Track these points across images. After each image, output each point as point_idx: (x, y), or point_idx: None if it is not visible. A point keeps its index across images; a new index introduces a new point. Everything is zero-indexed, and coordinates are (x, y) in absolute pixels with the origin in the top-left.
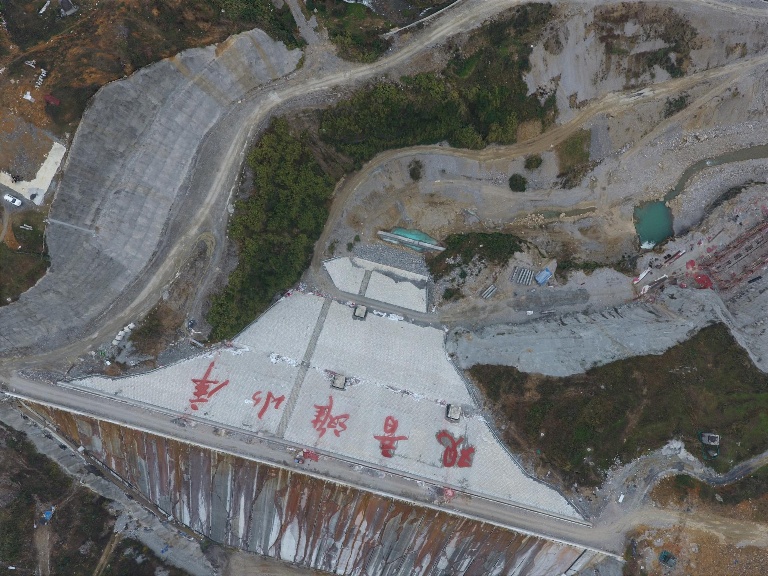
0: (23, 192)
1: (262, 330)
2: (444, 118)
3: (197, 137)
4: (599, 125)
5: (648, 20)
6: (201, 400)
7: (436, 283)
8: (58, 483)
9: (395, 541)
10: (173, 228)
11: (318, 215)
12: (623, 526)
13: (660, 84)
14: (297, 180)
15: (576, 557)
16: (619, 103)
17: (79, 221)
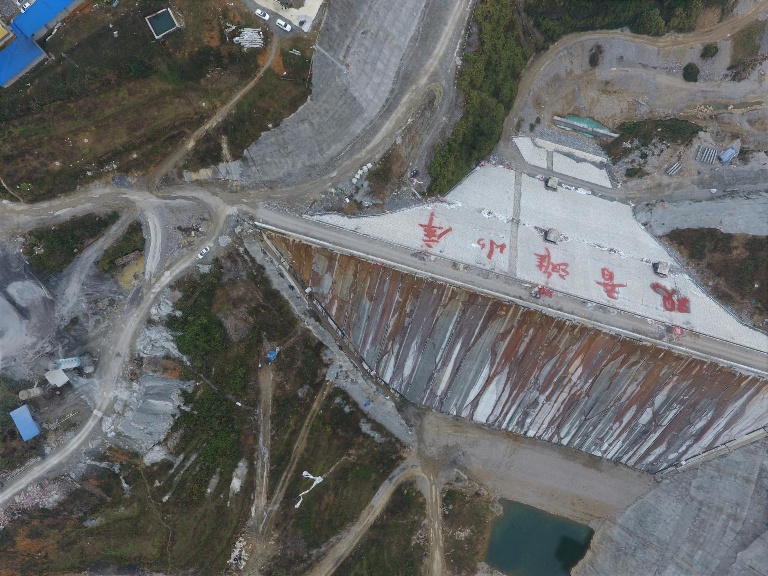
0: (292, 19)
1: (468, 191)
2: None
3: None
4: None
5: None
6: (433, 241)
7: (615, 165)
8: (287, 322)
9: (604, 391)
10: (404, 77)
11: (513, 88)
12: None
13: None
14: (504, 47)
15: None
16: None
17: (335, 54)
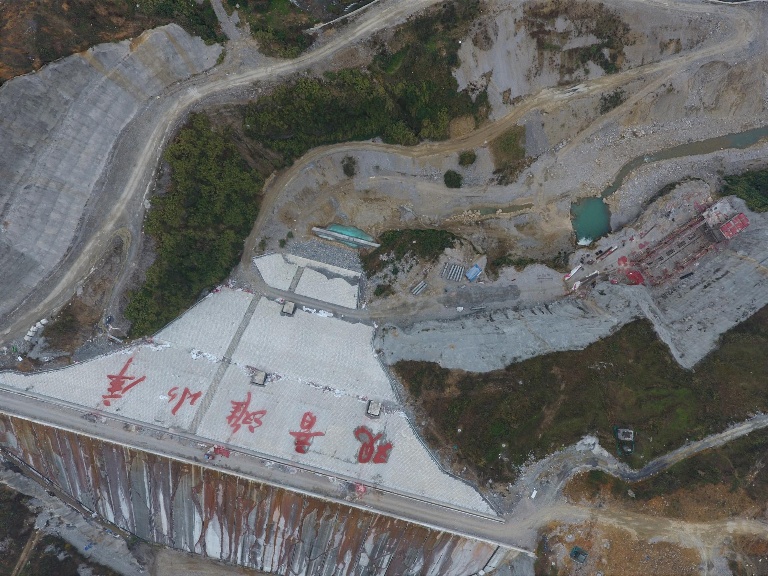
0: None
1: (185, 326)
2: (373, 114)
3: (114, 132)
4: (533, 121)
5: (579, 16)
6: (114, 396)
7: (369, 279)
8: None
9: (314, 538)
10: (88, 223)
11: (246, 211)
12: (535, 522)
13: (595, 80)
14: (221, 176)
15: (491, 553)
16: (553, 99)
17: None
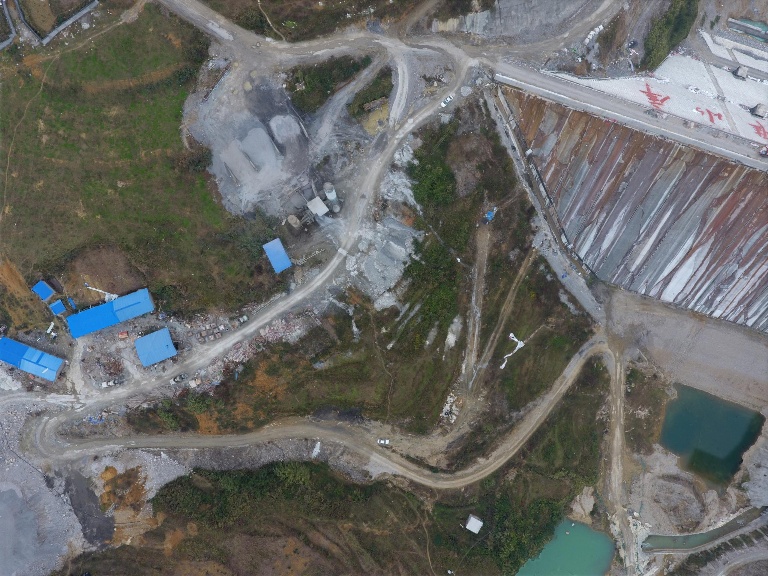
0: None
1: (671, 71)
2: None
3: None
4: None
5: None
6: (658, 103)
7: None
8: (509, 181)
9: None
10: None
11: None
12: None
13: None
14: None
15: None
16: None
17: None
